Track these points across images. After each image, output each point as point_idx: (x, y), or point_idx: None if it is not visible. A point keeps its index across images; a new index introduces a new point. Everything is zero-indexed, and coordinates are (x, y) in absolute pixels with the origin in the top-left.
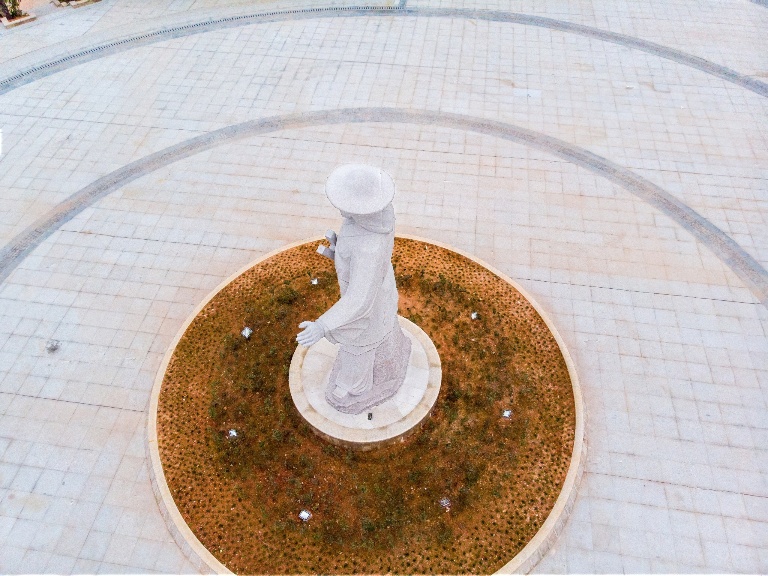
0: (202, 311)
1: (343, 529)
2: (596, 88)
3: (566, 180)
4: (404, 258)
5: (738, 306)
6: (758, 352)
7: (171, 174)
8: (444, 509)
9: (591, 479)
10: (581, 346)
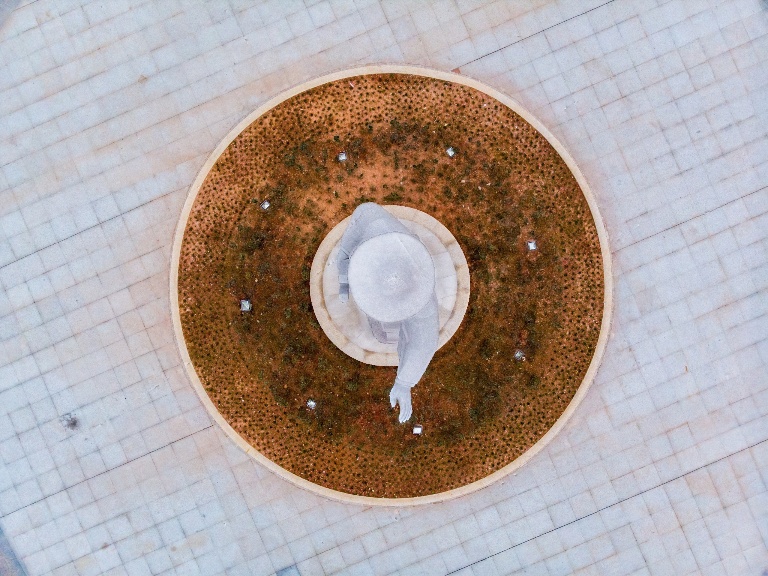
0: (180, 307)
1: None
2: None
3: None
4: (337, 115)
5: None
6: (729, 26)
7: None
8: (521, 360)
9: (620, 257)
10: (562, 119)
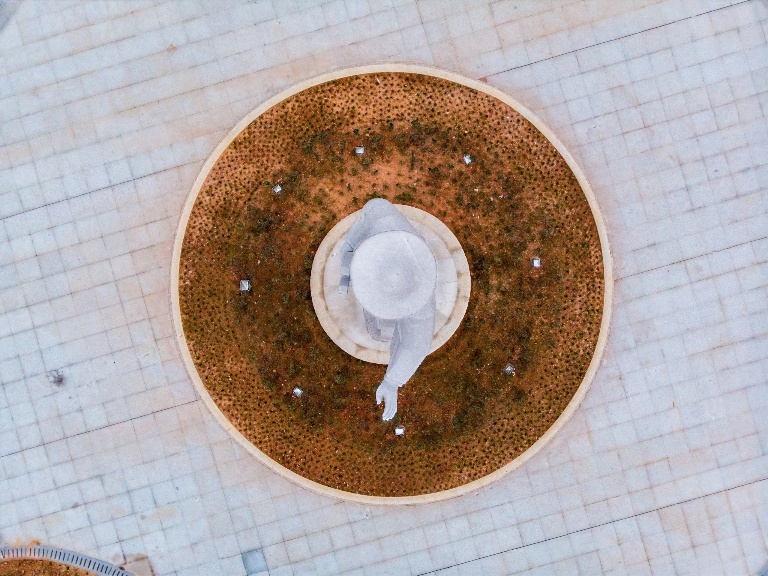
0: (180, 279)
1: None
2: None
3: None
4: (359, 109)
5: (736, 10)
6: (760, 69)
7: None
8: (511, 375)
9: (622, 285)
10: (582, 141)
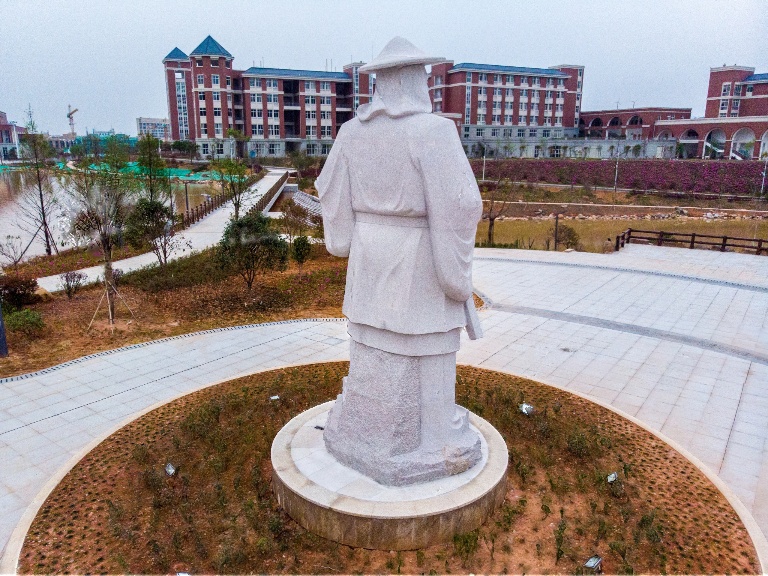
0: (580, 397)
1: (234, 399)
2: None
3: None
4: None
5: None
6: None
7: None
8: None
9: None
10: None
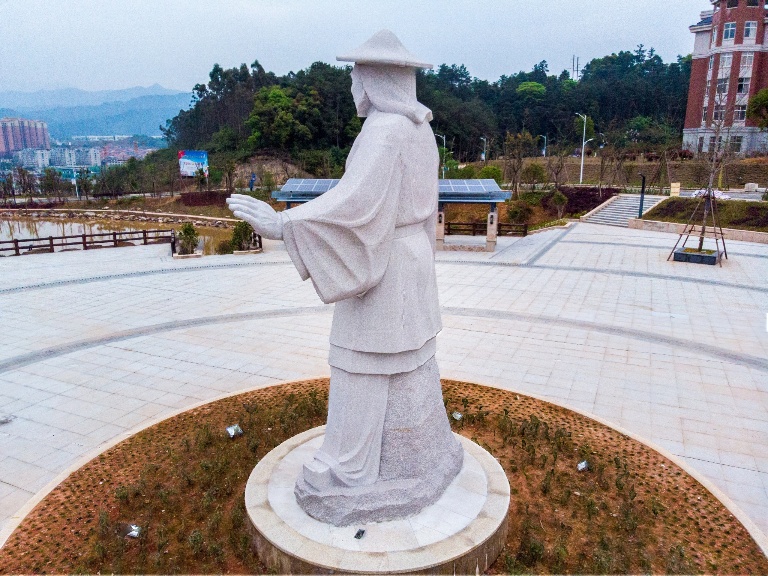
0: (194, 409)
1: None
2: (763, 319)
3: (732, 376)
4: (483, 402)
5: None
6: None
7: (243, 326)
8: None
9: None
10: None
